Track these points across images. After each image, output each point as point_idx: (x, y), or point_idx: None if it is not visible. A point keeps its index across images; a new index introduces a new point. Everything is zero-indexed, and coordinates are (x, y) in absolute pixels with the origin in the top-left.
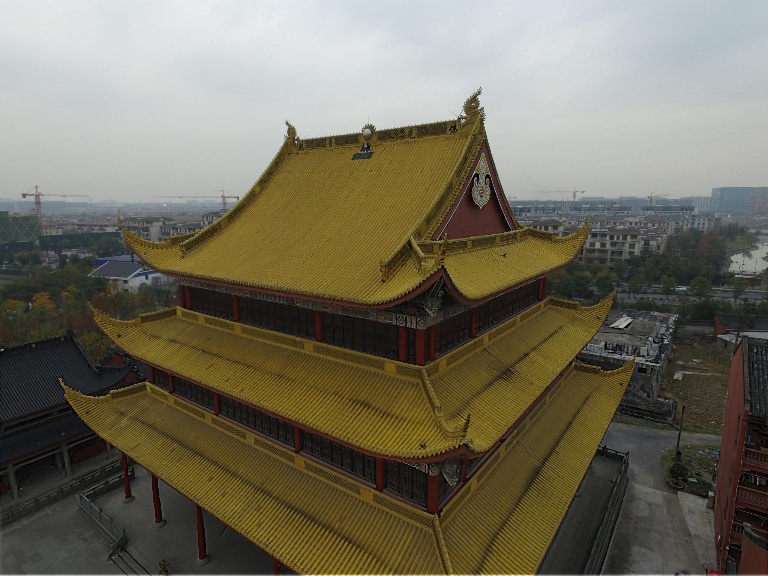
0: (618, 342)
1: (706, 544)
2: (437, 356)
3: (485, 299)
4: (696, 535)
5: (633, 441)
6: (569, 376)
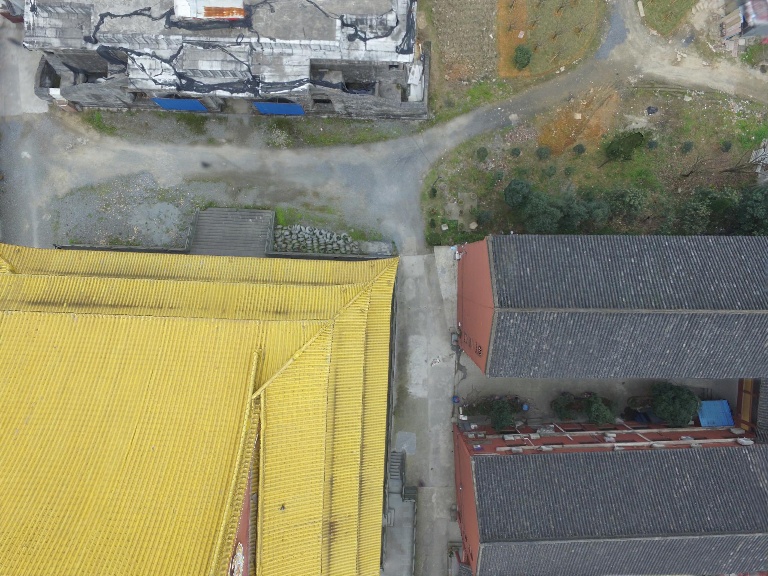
0: (357, 8)
1: (452, 306)
2: None
3: None
4: (446, 299)
5: (395, 179)
6: None
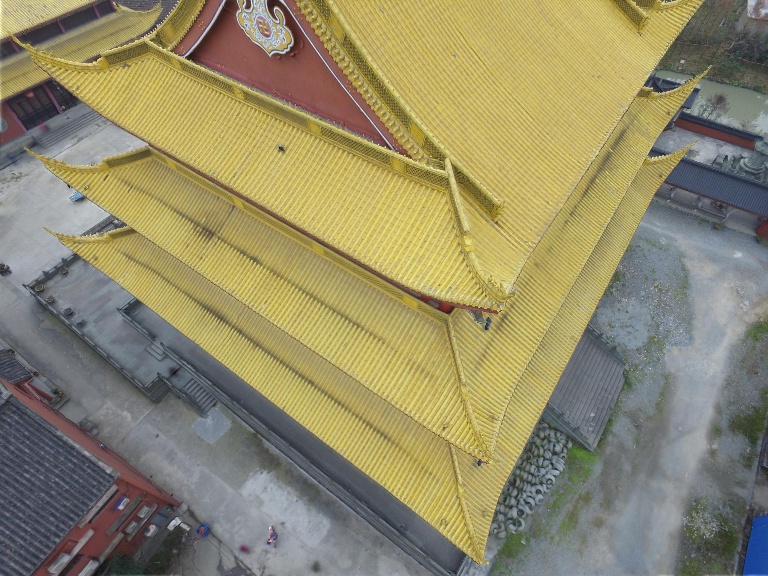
0: None
1: None
2: None
3: None
4: None
5: None
6: None
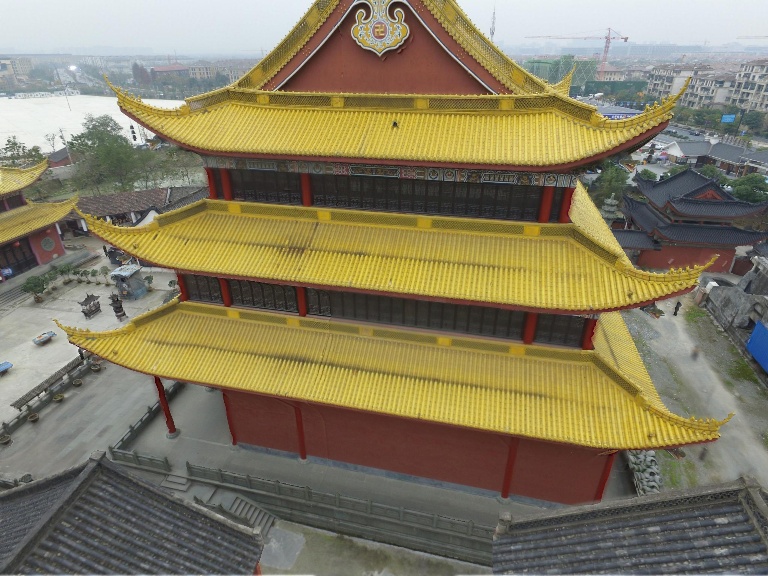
0: None
1: None
2: (238, 200)
3: (234, 155)
4: None
5: None
6: (560, 359)
